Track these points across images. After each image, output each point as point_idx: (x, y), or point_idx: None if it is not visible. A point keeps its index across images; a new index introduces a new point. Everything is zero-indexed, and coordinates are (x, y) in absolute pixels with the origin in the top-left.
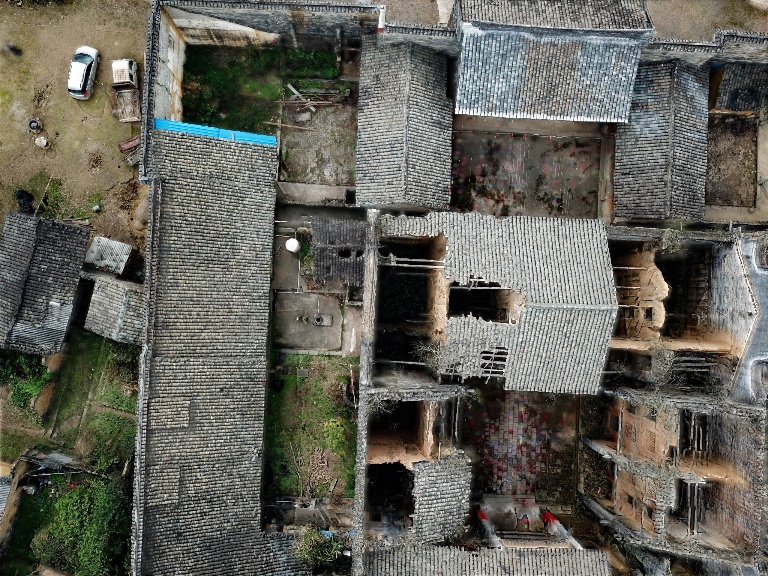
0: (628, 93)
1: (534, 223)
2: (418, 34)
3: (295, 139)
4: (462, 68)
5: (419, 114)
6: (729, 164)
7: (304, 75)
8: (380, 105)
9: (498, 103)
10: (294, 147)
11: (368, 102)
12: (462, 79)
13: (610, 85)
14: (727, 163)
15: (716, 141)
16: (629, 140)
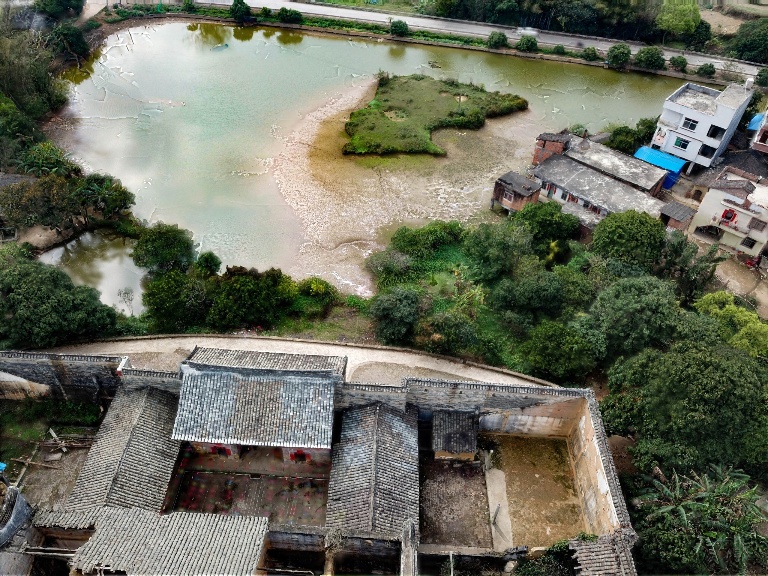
0: (328, 423)
1: (194, 519)
2: (150, 376)
3: (38, 476)
4: (180, 400)
5: (142, 442)
6: (462, 505)
7: (66, 422)
8: (111, 436)
9: (211, 430)
10: (33, 483)
11: (103, 435)
12: (180, 409)
13: (311, 416)
14: (460, 504)
15: (447, 484)
16: (341, 469)
